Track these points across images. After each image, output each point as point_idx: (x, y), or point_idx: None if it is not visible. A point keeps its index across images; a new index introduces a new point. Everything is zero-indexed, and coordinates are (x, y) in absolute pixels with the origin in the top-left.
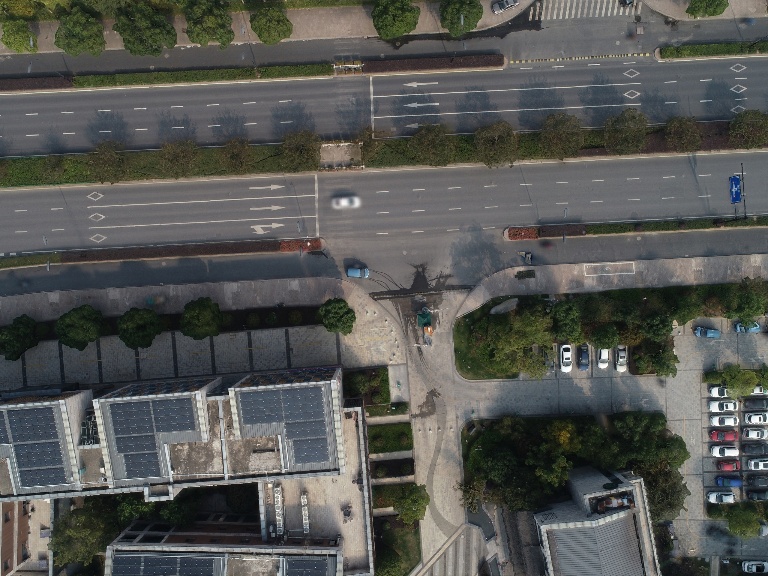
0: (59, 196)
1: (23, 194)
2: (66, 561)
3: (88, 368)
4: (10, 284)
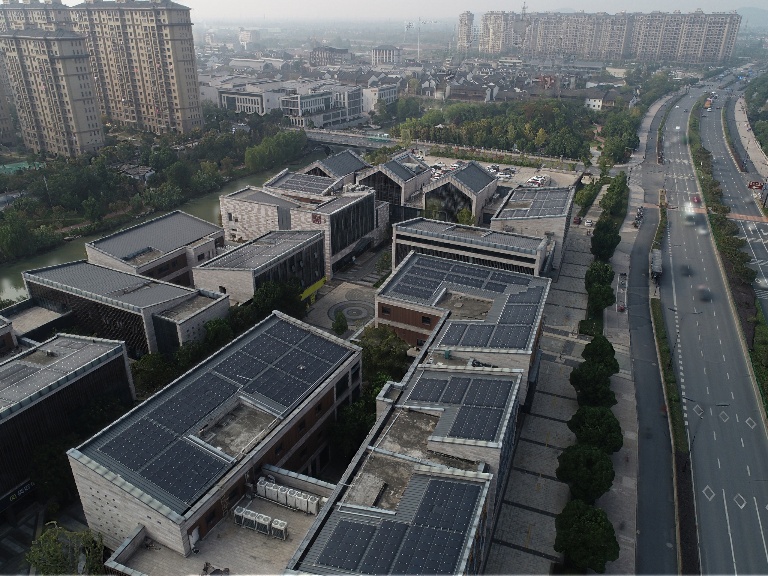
0: (767, 477)
1: (765, 450)
2: (366, 332)
3: (540, 435)
4: (650, 412)
